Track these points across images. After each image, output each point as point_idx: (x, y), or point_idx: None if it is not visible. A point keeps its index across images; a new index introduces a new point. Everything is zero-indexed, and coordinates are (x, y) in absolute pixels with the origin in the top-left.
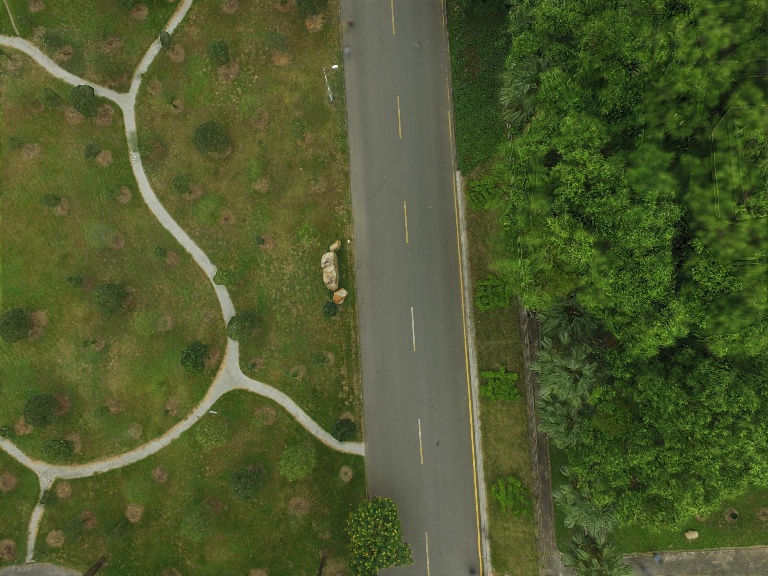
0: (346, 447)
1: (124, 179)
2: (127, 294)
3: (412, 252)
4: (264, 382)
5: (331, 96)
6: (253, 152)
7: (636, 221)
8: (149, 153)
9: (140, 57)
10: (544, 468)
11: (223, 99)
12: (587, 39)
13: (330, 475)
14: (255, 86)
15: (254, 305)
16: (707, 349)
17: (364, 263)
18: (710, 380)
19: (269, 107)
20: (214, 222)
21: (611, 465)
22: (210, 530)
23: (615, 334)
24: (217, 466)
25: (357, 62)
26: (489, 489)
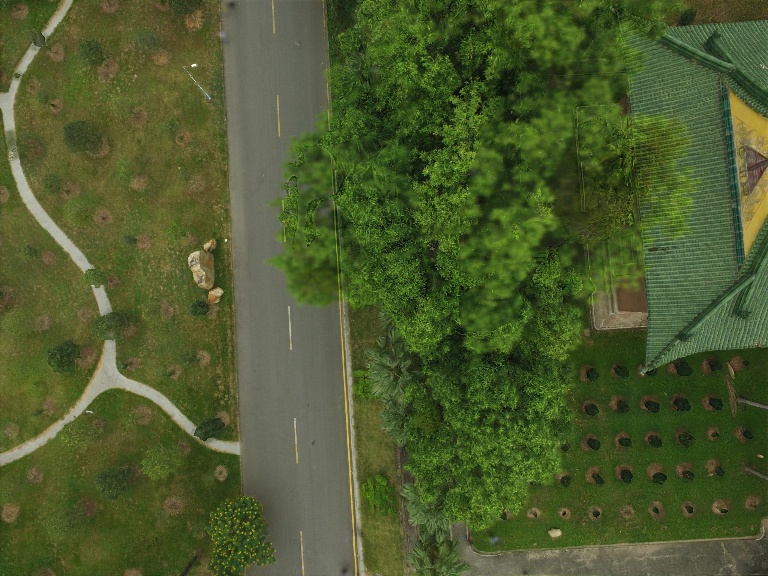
0: (221, 446)
1: (2, 179)
2: (1, 294)
3: (290, 251)
4: (141, 381)
5: (209, 95)
6: (132, 151)
7: (358, 217)
8: (27, 152)
9: (20, 56)
10: None
11: (102, 98)
12: (371, 36)
13: (205, 474)
14: (134, 85)
15: (131, 304)
16: (488, 346)
17: (242, 262)
18: (474, 377)
19: (148, 106)
20: (91, 221)
21: (424, 463)
22: (77, 530)
23: (402, 331)
24: (93, 466)
25: (237, 61)
26: (361, 488)
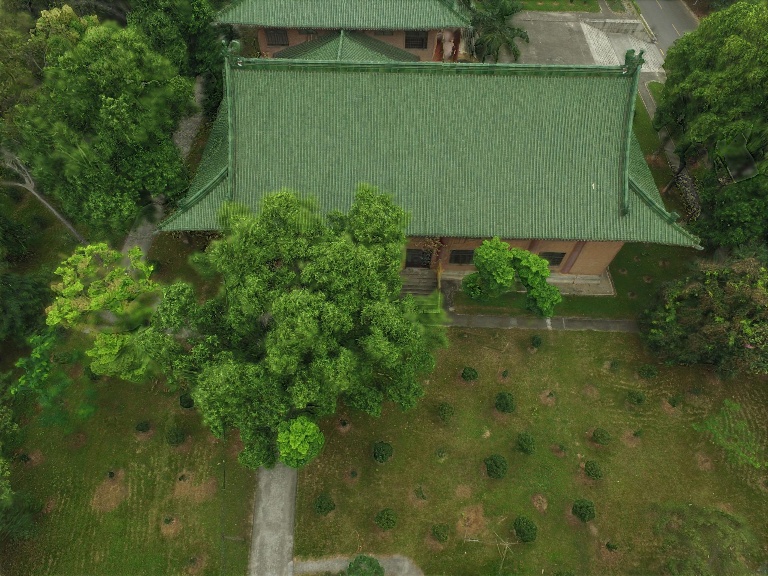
0: None
1: None
2: None
3: None
4: None
5: None
6: None
7: None
8: None
9: None
10: None
11: None
12: None
13: None
14: None
15: None
16: None
17: None
18: None
19: None
20: None
21: None
22: None
23: None
24: None
25: None
26: None
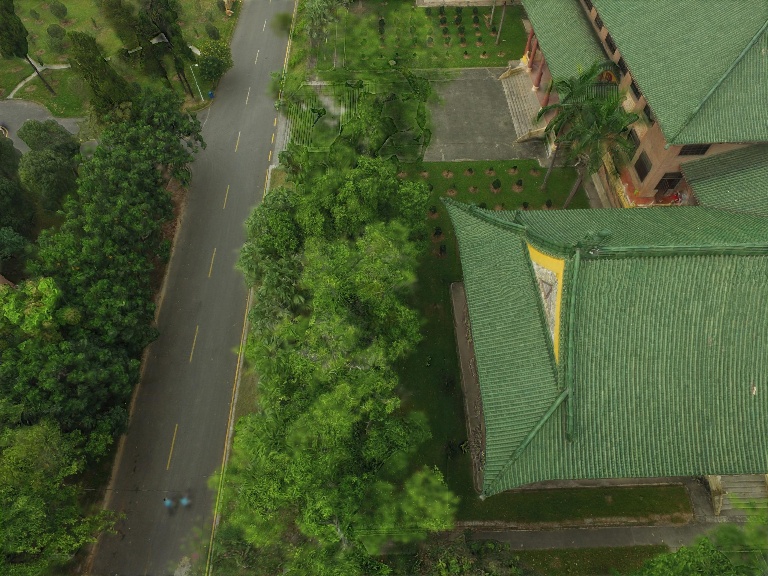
0: None
1: None
2: None
3: (271, 5)
4: None
5: None
6: None
7: None
8: None
9: None
10: (316, 44)
11: None
12: None
13: None
14: None
15: None
16: None
17: (246, 8)
18: None
19: None
20: None
21: None
22: (125, 65)
23: None
24: None
25: None
26: None
